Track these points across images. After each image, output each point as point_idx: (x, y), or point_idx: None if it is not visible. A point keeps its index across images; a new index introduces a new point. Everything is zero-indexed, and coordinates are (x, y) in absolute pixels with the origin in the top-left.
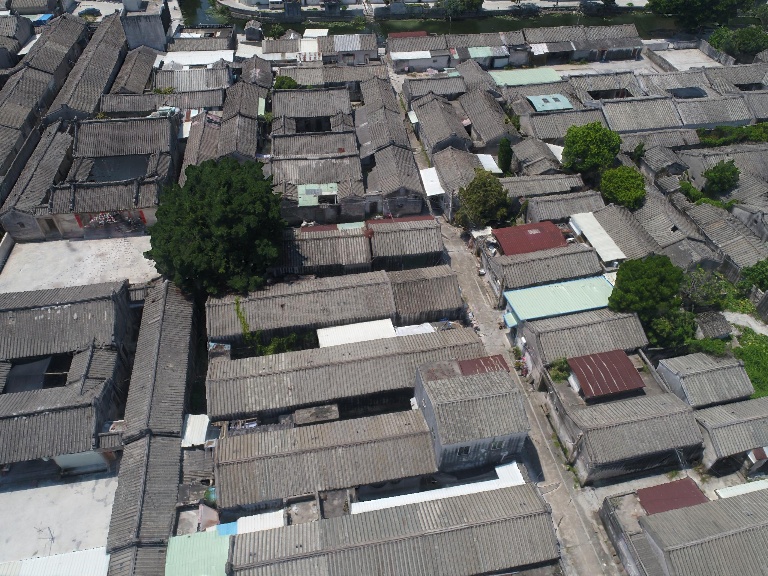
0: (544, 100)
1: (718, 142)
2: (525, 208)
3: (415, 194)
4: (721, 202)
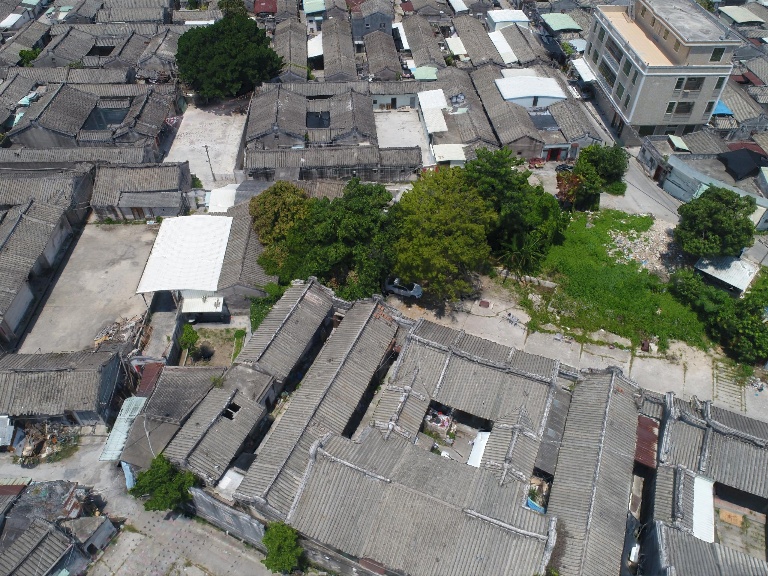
0: None
1: None
2: None
3: None
4: None
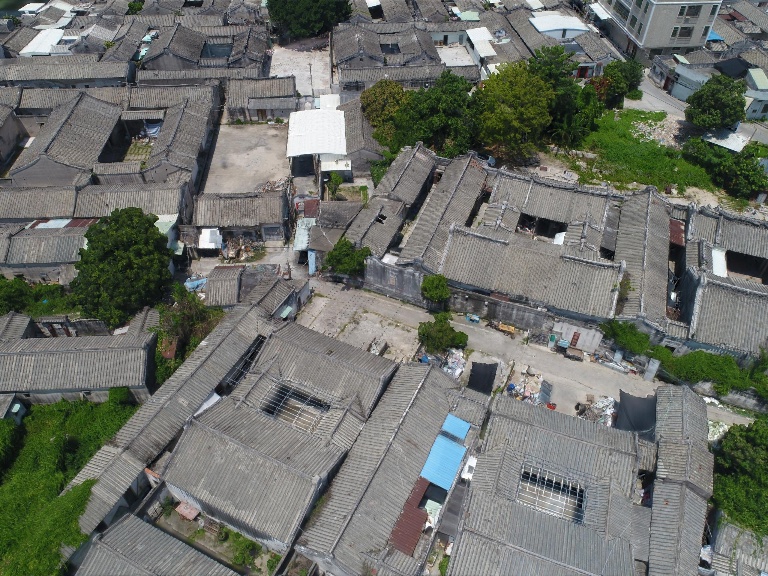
0: None
1: None
2: None
3: None
4: None
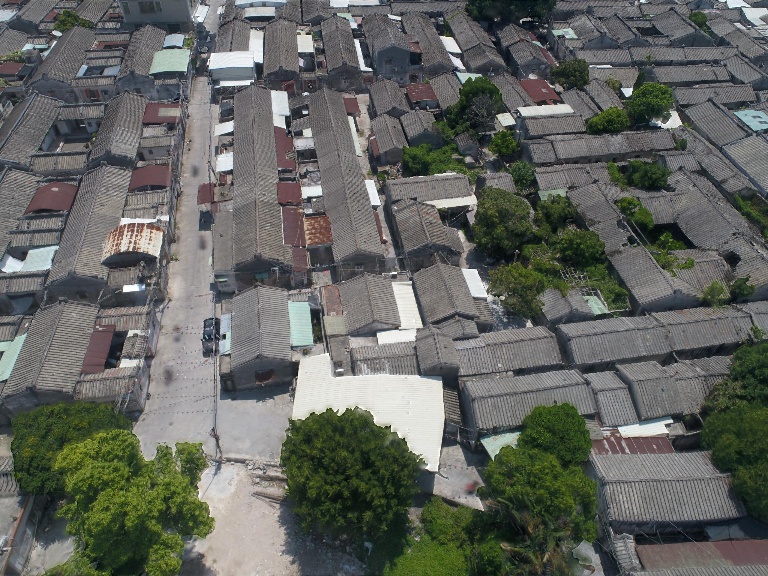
0: (757, 116)
1: None
2: None
3: None
4: (617, 176)
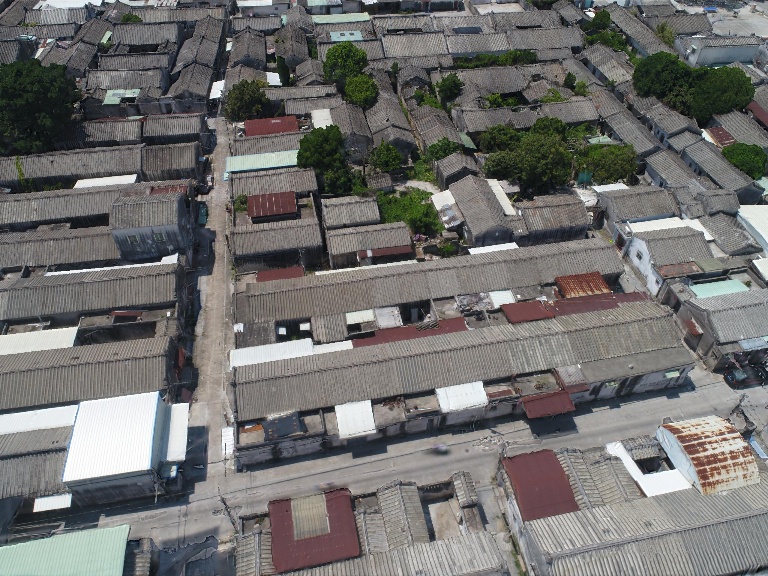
0: (341, 34)
1: (471, 66)
2: (283, 108)
3: (198, 97)
4: (440, 105)
